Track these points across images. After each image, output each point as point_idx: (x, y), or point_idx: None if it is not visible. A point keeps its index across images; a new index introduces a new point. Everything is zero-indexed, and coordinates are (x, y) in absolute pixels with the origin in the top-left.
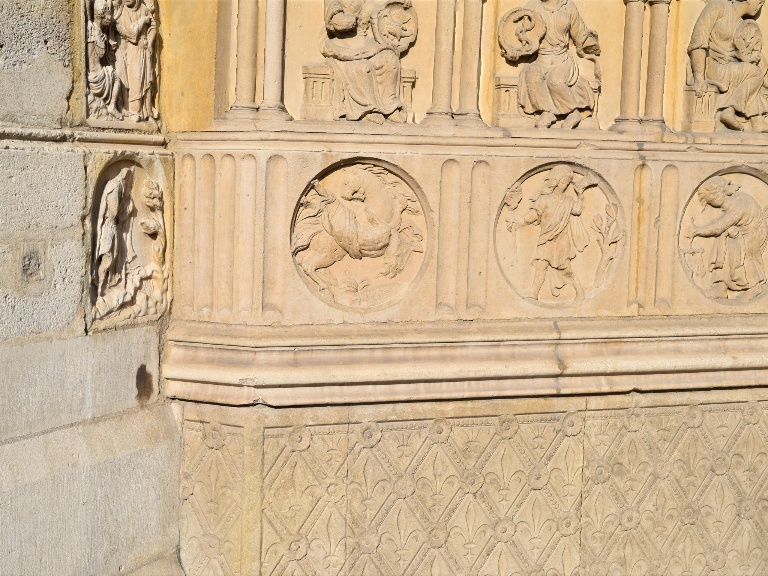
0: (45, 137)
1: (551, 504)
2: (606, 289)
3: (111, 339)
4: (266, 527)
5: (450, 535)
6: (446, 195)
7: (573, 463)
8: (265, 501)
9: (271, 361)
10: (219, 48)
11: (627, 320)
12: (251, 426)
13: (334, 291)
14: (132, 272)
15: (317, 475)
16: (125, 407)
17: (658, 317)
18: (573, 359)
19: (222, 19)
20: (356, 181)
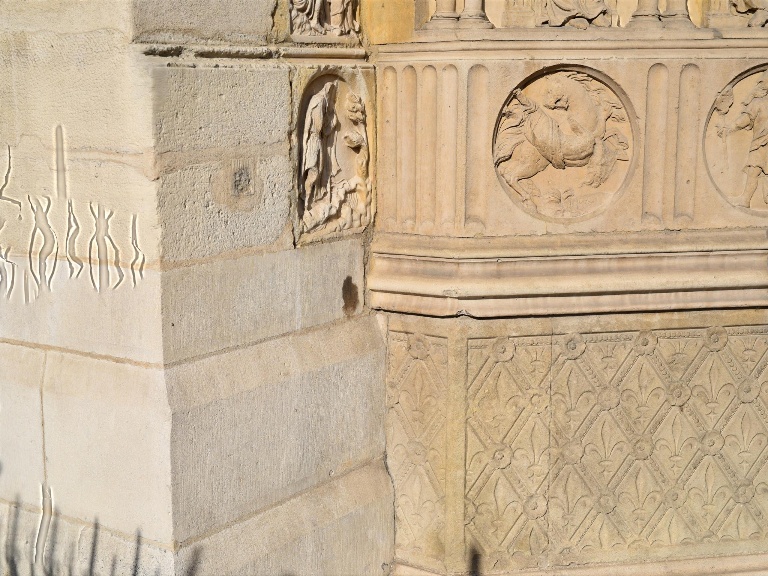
0: (252, 54)
1: (761, 418)
2: None
3: (318, 252)
4: (470, 436)
5: (656, 447)
6: (653, 101)
7: None
8: (469, 411)
9: (474, 273)
10: None
11: None
12: (455, 337)
13: (537, 202)
14: (337, 186)
15: (521, 386)
16: (332, 318)
17: None
18: None
19: None
20: (559, 89)
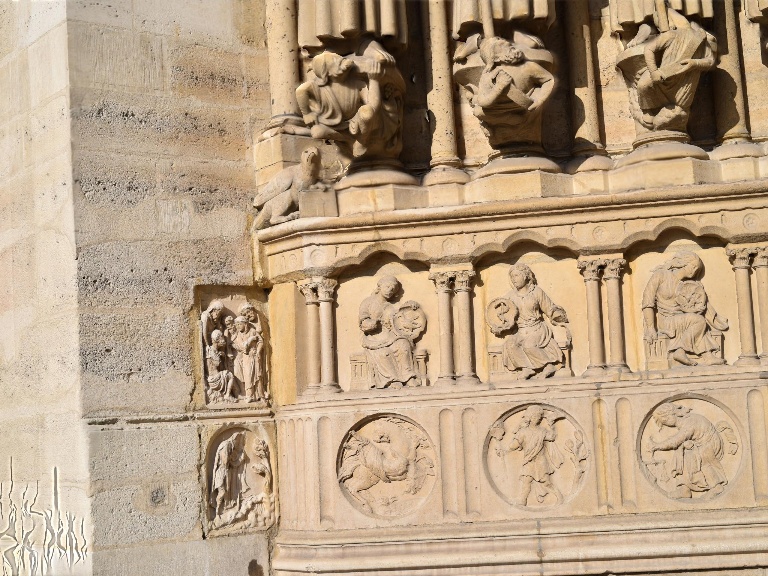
0: (171, 419)
1: None
2: (578, 495)
3: (225, 542)
4: None
5: None
6: (446, 434)
7: None
8: None
9: (327, 555)
10: (299, 350)
11: (599, 518)
12: None
13: (373, 505)
14: (247, 499)
15: None
16: None
17: (627, 515)
18: (552, 549)
19: (300, 332)
20: (381, 429)
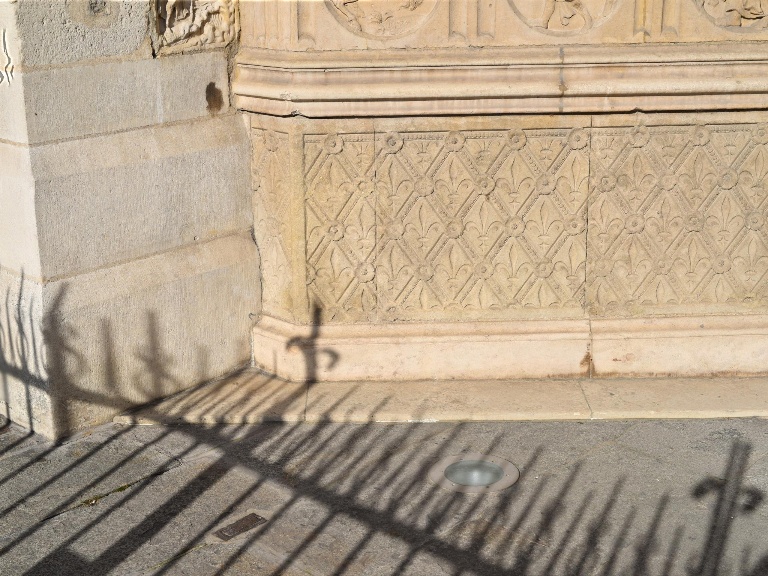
0: None
1: (559, 207)
2: (612, 18)
3: (179, 61)
4: (309, 213)
5: (466, 228)
6: None
7: (579, 173)
8: (308, 193)
9: (306, 80)
10: None
11: (633, 47)
12: (293, 133)
13: (362, 22)
14: (201, 8)
15: (350, 174)
16: (196, 115)
17: (665, 44)
18: (576, 81)
19: None
20: None
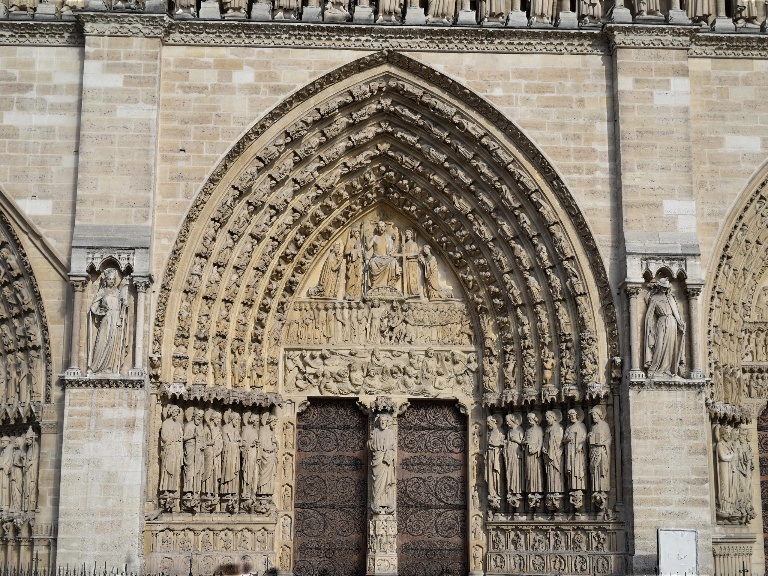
0: None
1: None
2: (193, 572)
3: None
4: None
5: None
6: (176, 561)
7: None
8: None
9: None
10: None
11: None
12: None
13: None
14: None
15: None
16: None
17: None
18: None
19: None
20: None
